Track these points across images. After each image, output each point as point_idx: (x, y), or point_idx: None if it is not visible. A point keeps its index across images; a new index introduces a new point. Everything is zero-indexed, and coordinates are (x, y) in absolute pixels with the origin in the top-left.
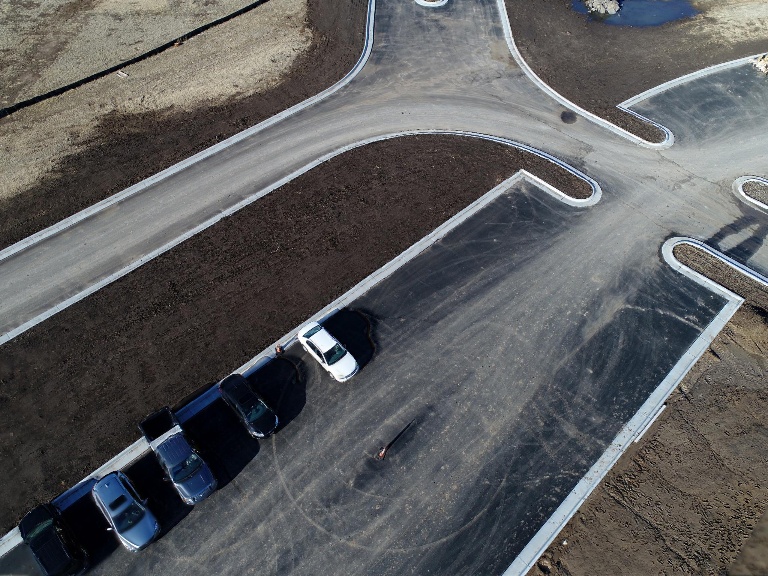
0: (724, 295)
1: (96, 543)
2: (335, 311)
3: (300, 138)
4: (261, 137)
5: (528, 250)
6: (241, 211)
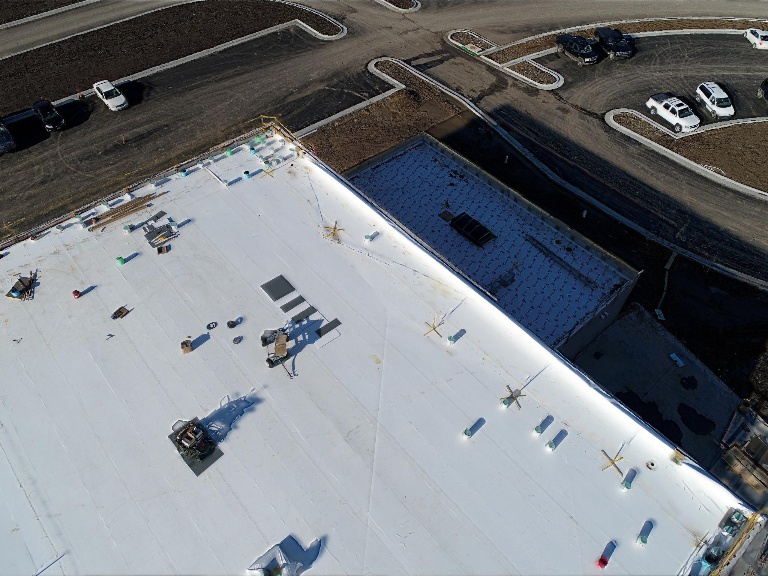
0: (395, 85)
1: None
2: (127, 81)
3: None
4: None
5: (275, 59)
6: (88, 33)
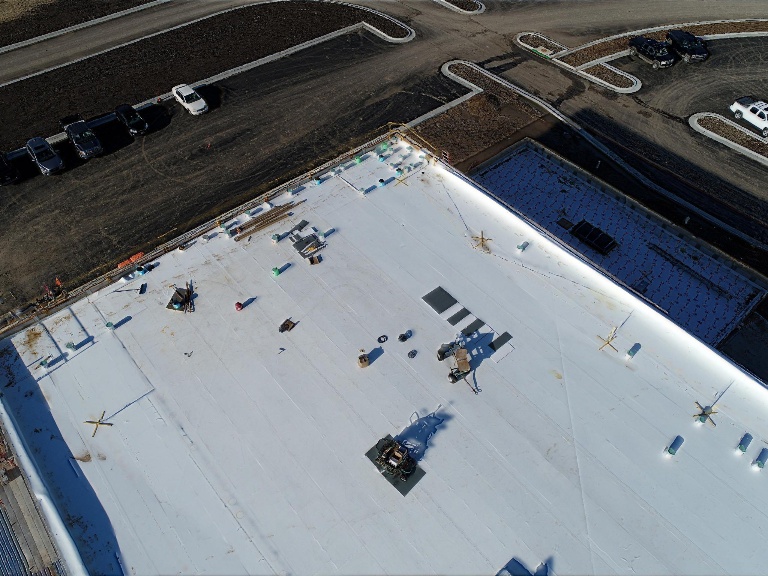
0: (472, 88)
1: (26, 173)
2: (203, 85)
3: (210, 1)
4: (183, 0)
5: (348, 62)
6: (156, 36)
